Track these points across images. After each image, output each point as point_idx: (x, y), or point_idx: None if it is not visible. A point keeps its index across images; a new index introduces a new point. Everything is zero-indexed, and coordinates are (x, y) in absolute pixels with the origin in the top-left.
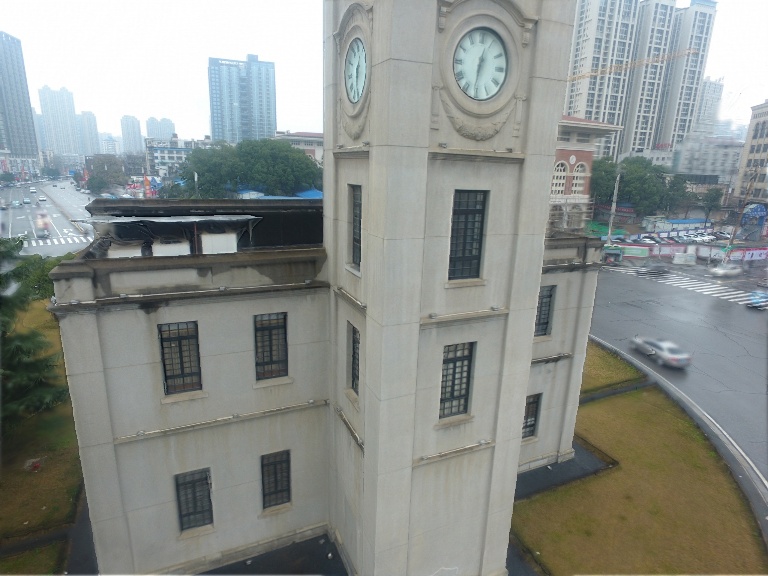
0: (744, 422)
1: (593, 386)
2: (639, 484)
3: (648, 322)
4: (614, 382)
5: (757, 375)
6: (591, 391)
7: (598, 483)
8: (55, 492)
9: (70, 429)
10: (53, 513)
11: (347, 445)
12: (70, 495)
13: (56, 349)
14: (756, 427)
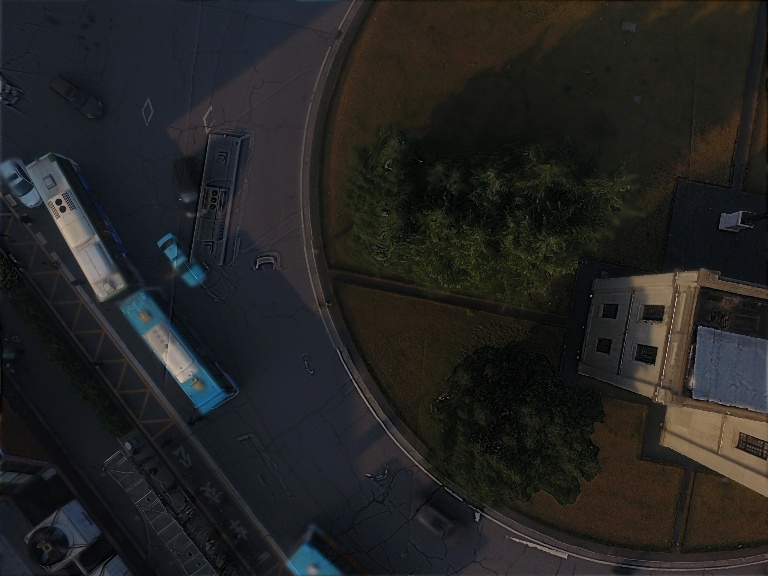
0: None
1: None
2: None
3: None
4: None
5: None
6: None
7: None
8: (561, 287)
9: None
10: (561, 304)
11: (713, 424)
12: (568, 294)
13: (559, 69)
14: None
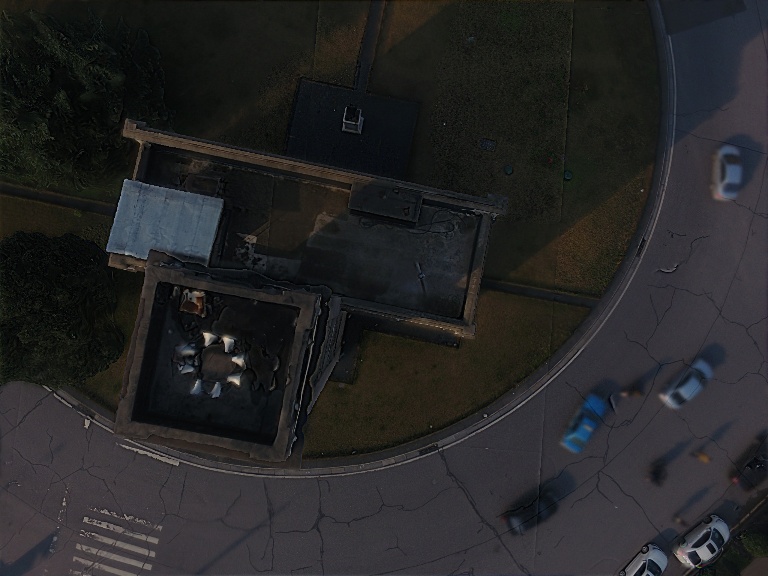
0: (593, 371)
1: (542, 282)
2: (450, 364)
3: (759, 223)
4: (565, 287)
5: (698, 348)
6: (532, 286)
7: (433, 349)
8: None
9: (184, 123)
10: None
11: None
12: None
13: None
14: (592, 378)
